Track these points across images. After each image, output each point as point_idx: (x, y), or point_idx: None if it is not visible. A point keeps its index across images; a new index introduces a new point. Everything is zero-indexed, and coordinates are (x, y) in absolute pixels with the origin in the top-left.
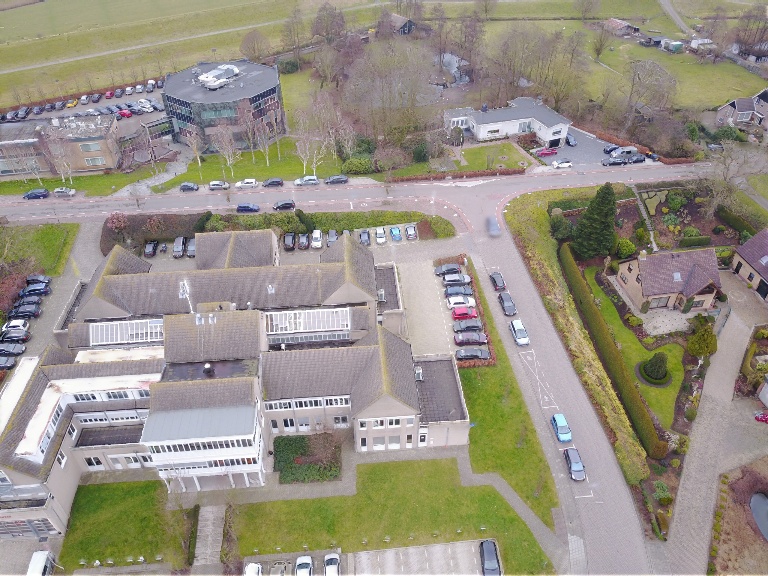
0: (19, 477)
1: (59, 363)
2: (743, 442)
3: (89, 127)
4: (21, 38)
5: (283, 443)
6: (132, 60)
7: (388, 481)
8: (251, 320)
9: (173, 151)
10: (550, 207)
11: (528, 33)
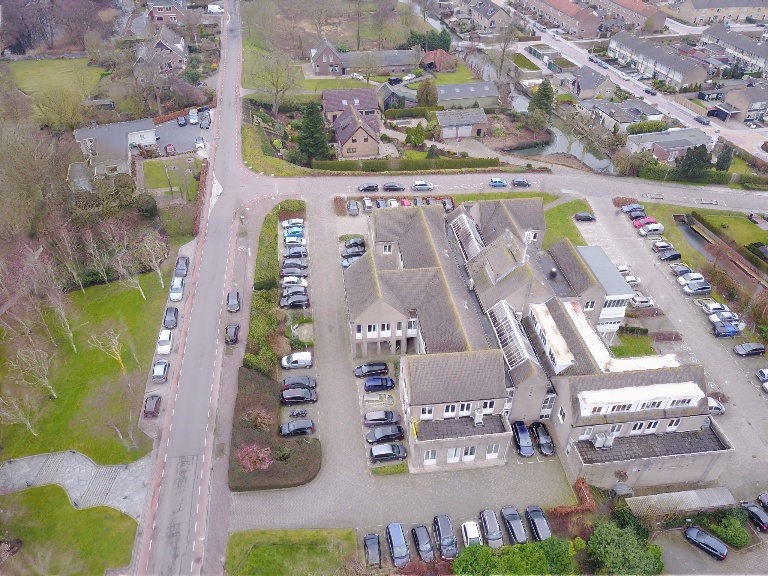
0: None
1: None
2: (477, 147)
3: None
4: None
5: None
6: None
7: None
8: None
9: None
10: None
11: None
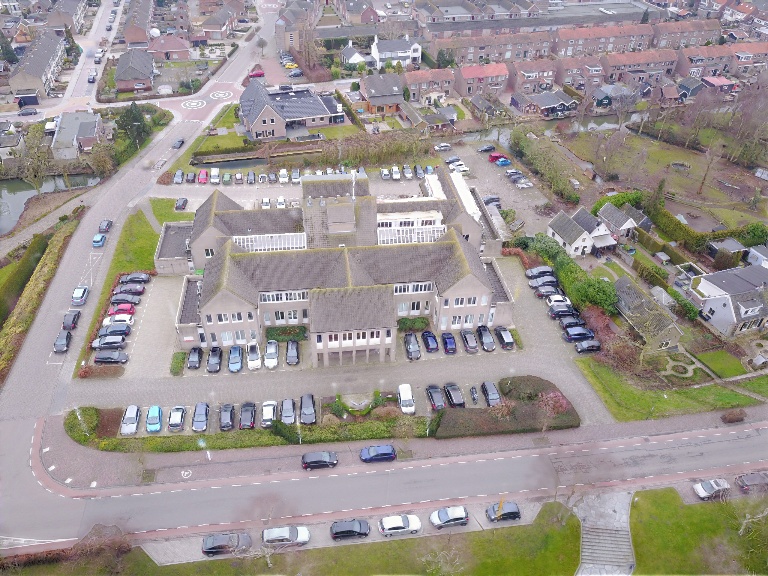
0: None
1: None
2: None
3: None
4: None
5: None
6: None
7: None
8: None
9: None
10: None
11: None
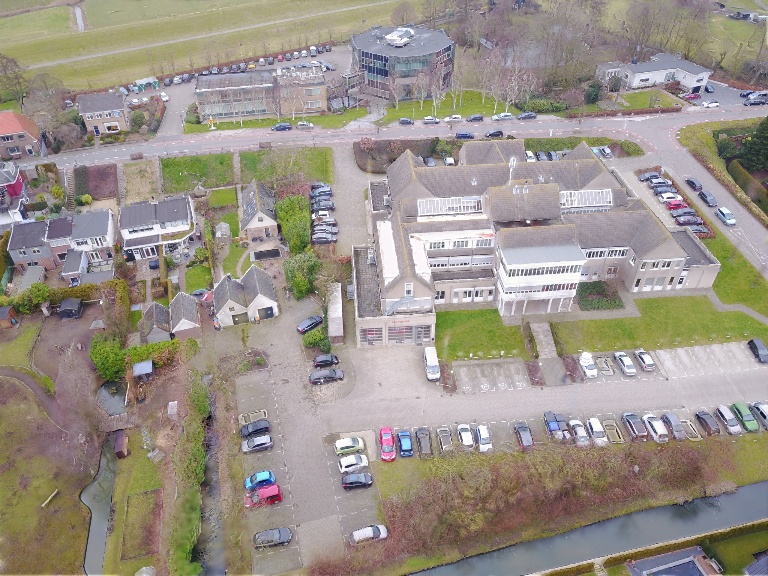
0: (420, 290)
1: None
2: None
3: (307, 76)
4: (169, 15)
5: None
6: (283, 31)
7: (662, 309)
8: (554, 191)
9: (364, 100)
10: (714, 134)
11: (647, 3)
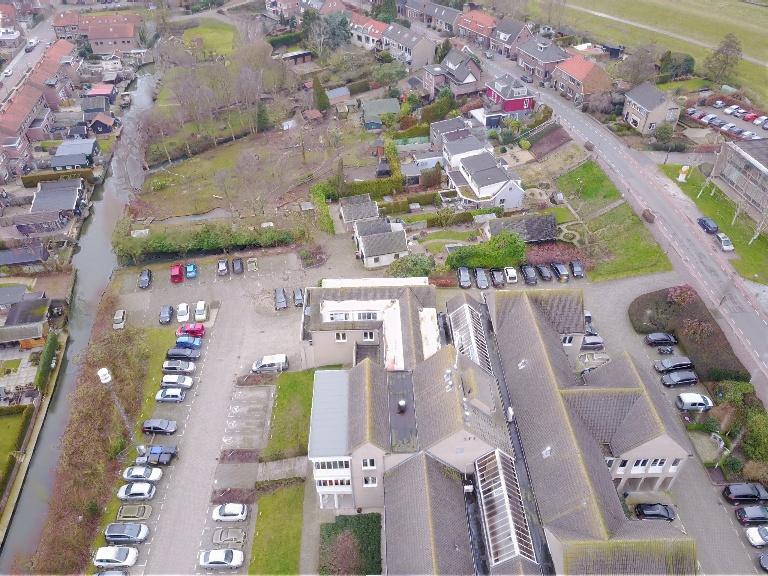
0: None
1: (421, 300)
2: None
3: None
4: None
5: (369, 521)
6: None
7: None
8: (452, 425)
9: None
10: None
11: None
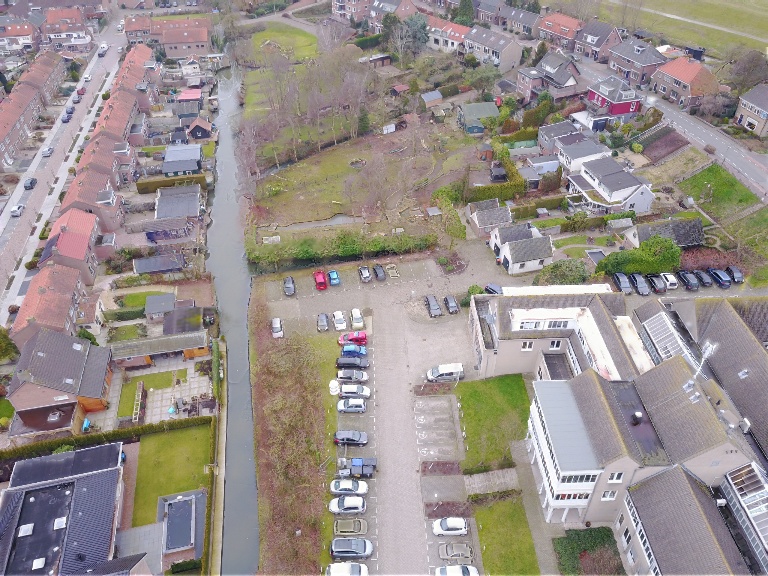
0: None
1: (610, 307)
2: None
3: None
4: None
5: (603, 536)
6: None
7: None
8: (713, 438)
9: None
10: None
11: None
